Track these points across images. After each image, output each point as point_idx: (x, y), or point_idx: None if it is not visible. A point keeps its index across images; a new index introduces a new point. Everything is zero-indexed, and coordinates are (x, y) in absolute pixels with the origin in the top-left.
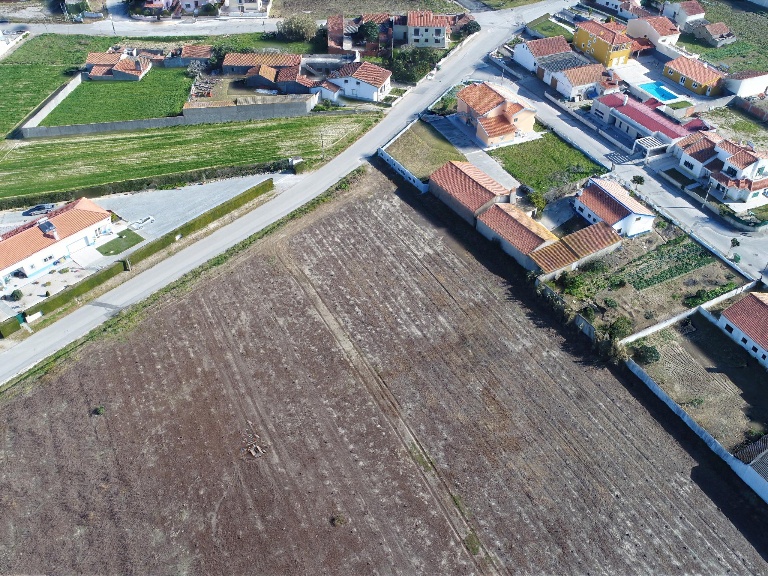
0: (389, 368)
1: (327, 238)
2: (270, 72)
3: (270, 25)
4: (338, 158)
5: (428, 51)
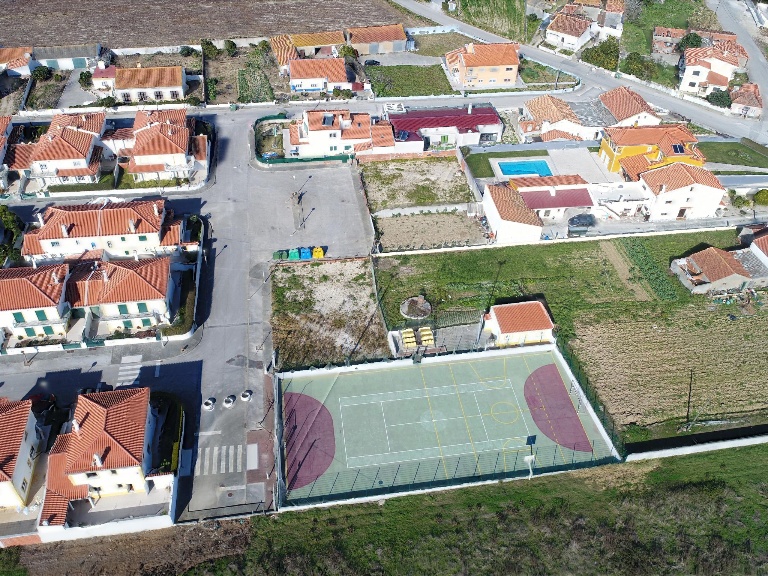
0: (248, 8)
1: (364, 8)
2: (591, 1)
3: (736, 24)
4: (458, 21)
5: (648, 68)
